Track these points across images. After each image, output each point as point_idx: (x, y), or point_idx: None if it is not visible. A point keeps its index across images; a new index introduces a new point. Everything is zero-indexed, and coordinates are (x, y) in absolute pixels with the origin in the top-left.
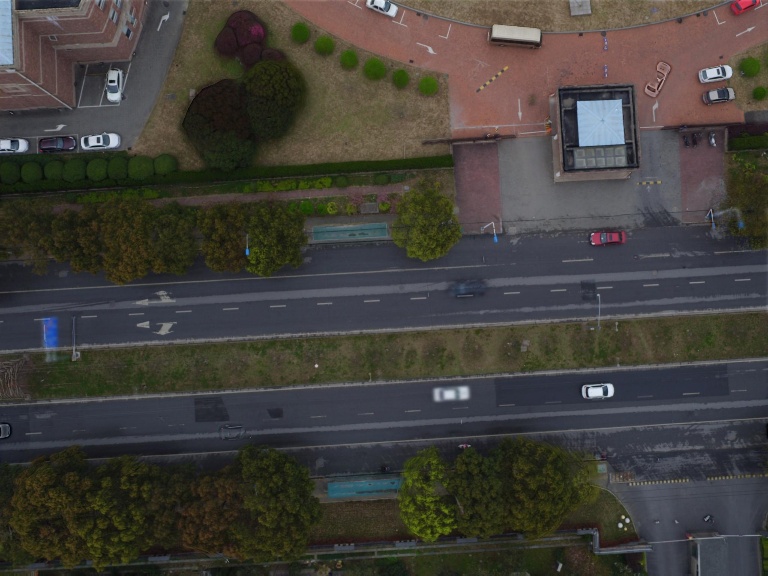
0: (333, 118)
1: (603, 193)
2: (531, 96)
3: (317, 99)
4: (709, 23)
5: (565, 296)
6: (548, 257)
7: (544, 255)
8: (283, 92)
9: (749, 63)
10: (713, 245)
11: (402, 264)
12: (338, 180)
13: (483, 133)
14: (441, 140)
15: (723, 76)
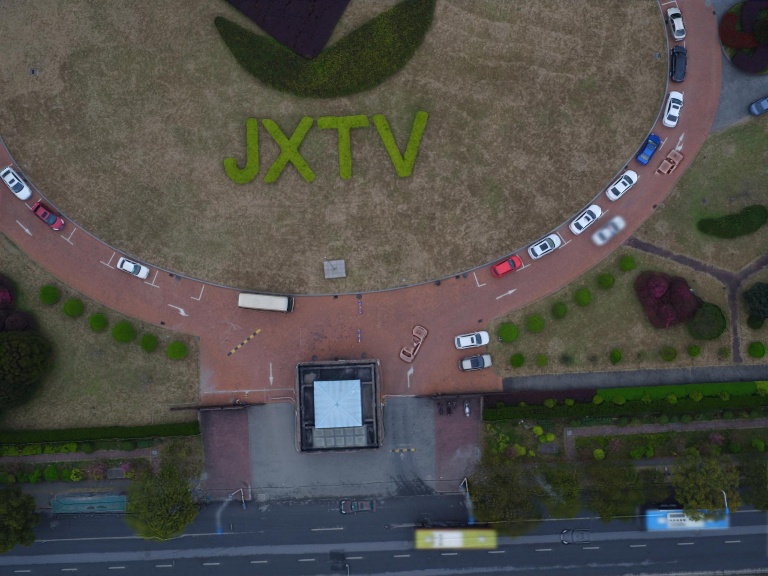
0: (82, 381)
1: (355, 460)
2: (283, 360)
3: (66, 361)
4: (469, 285)
5: (313, 566)
6: (297, 525)
7: (293, 523)
8: (14, 372)
9: (505, 331)
10: (467, 515)
11: (146, 533)
12: (82, 447)
13: (233, 398)
14: (188, 406)
15: (478, 344)
